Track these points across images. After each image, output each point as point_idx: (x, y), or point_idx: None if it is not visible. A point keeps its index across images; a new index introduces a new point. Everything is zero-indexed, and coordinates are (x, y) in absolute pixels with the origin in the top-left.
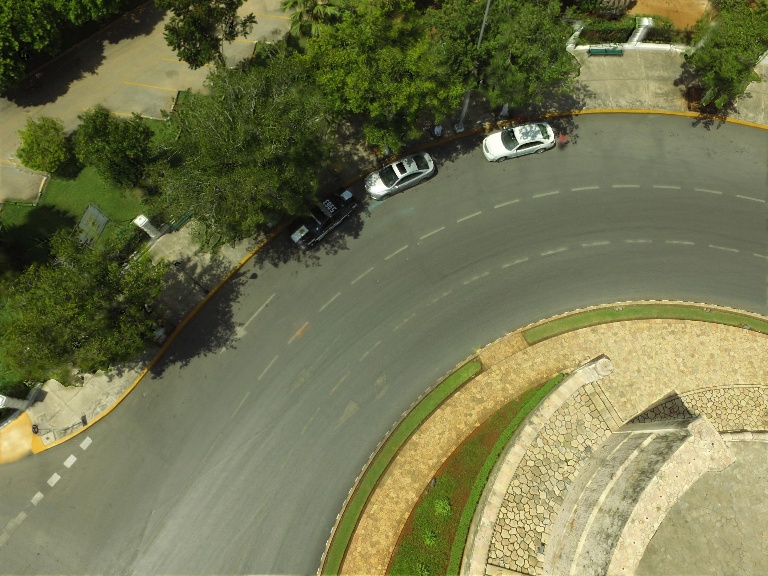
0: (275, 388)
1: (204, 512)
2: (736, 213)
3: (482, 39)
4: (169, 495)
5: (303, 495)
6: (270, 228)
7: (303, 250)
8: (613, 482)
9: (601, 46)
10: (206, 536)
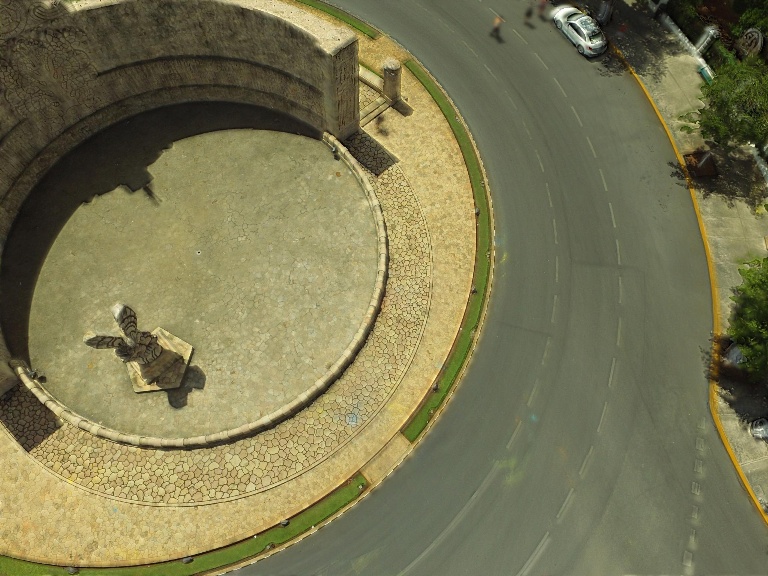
0: None
1: None
2: (591, 203)
3: None
4: None
5: None
6: None
7: None
8: None
9: (713, 73)
10: None
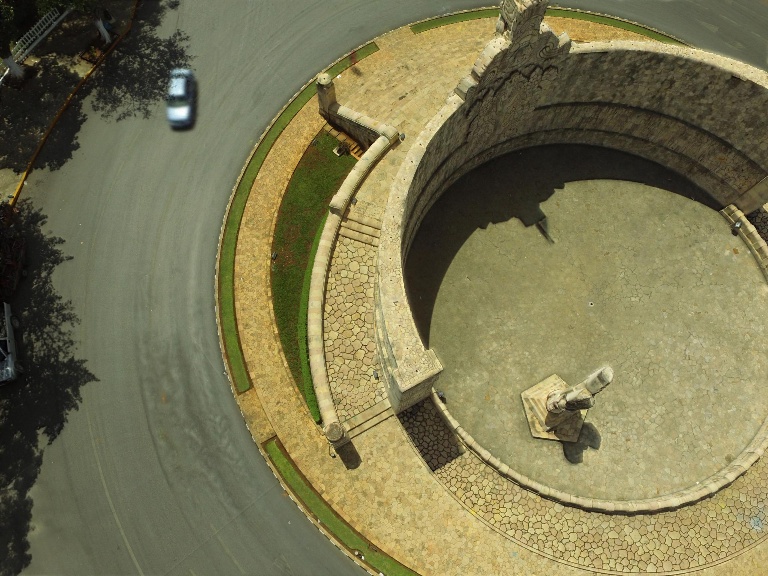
0: None
1: None
2: None
3: None
4: None
5: (645, 3)
6: None
7: None
8: None
9: None
10: None
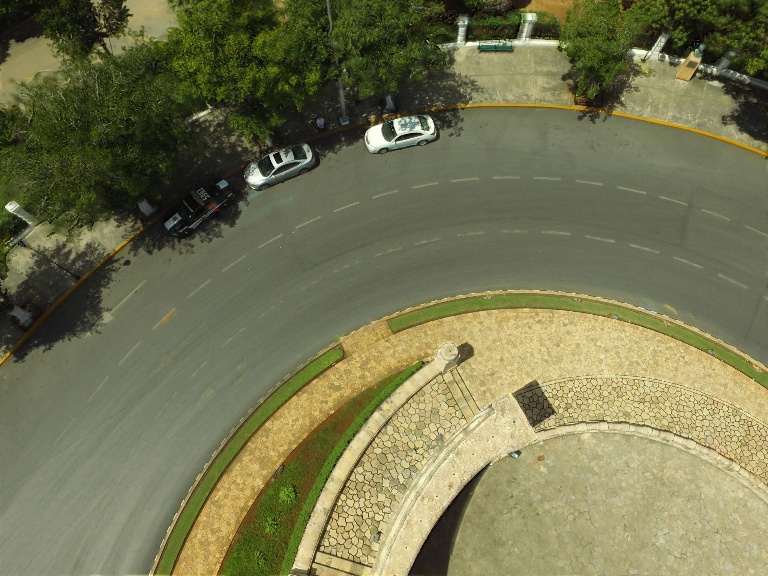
0: (134, 373)
1: (48, 496)
2: (615, 204)
3: (333, 26)
4: (16, 478)
5: (150, 480)
6: (147, 216)
7: (178, 238)
8: (434, 465)
9: (490, 42)
10: (47, 520)
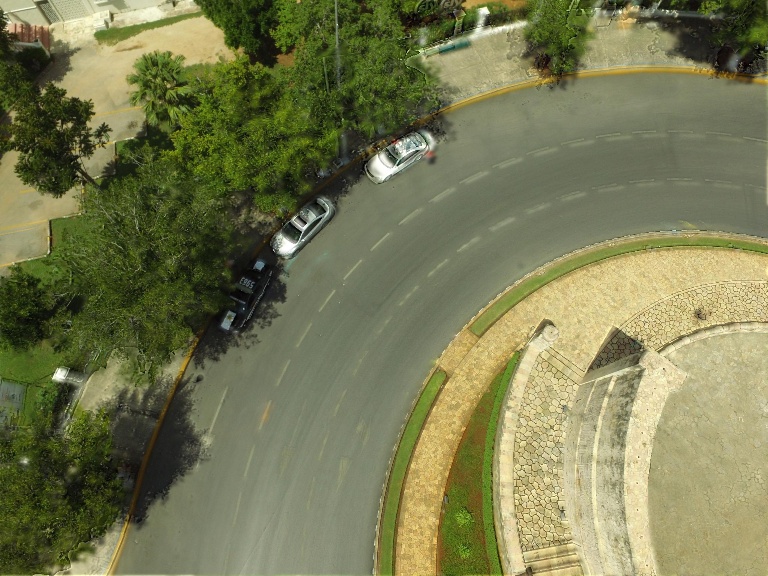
0: (265, 477)
1: None
2: (601, 152)
3: (329, 84)
4: None
5: (333, 567)
6: (197, 325)
7: (238, 334)
8: (598, 433)
9: (433, 46)
10: None
